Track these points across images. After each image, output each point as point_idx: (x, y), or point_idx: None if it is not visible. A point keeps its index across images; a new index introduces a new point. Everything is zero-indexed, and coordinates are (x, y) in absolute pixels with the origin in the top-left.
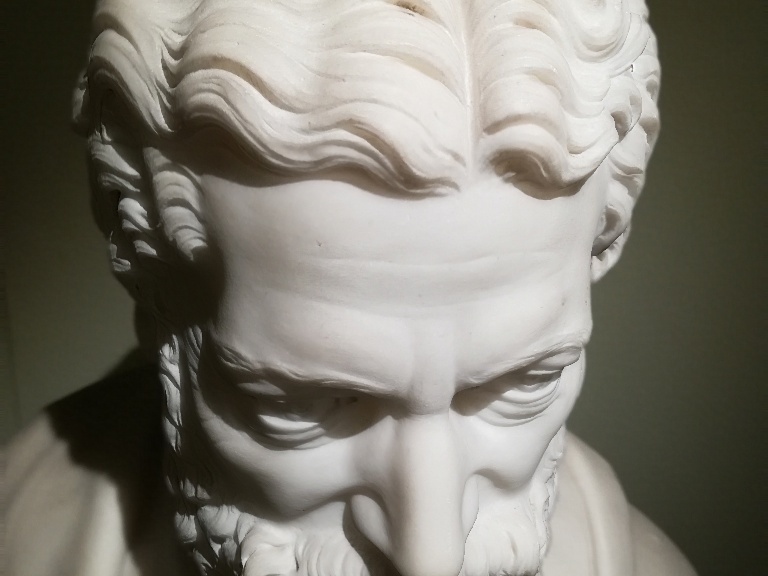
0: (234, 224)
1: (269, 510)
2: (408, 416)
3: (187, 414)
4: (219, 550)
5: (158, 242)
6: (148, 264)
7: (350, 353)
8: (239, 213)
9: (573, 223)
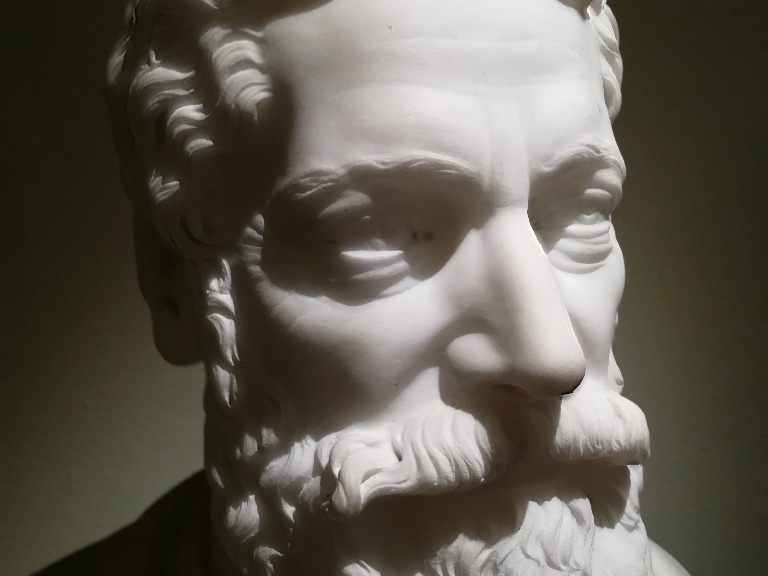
0: (303, 48)
1: (355, 404)
2: (492, 213)
3: (245, 341)
4: (293, 513)
5: (215, 128)
6: (199, 173)
7: (433, 127)
8: (307, 36)
9: (587, 45)
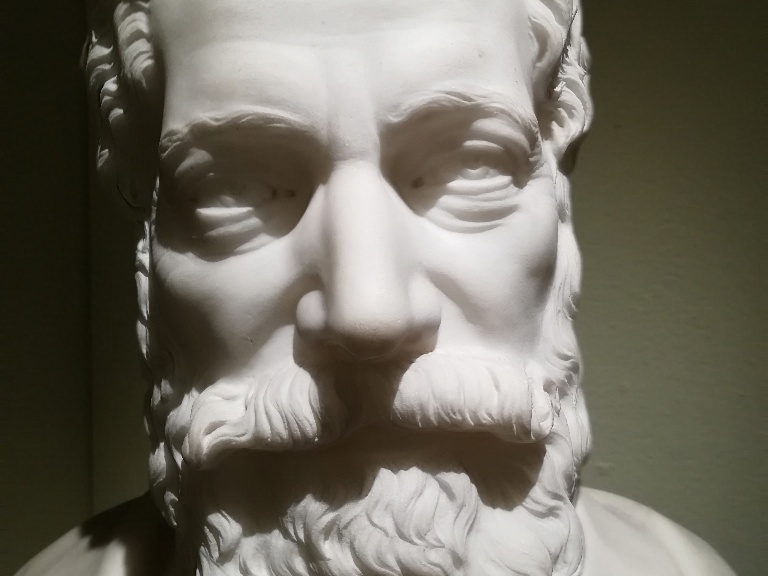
0: (169, 14)
1: (220, 358)
2: (333, 168)
3: (153, 297)
4: (182, 461)
5: (124, 97)
6: (121, 140)
7: (261, 81)
8: (172, 2)
9: None
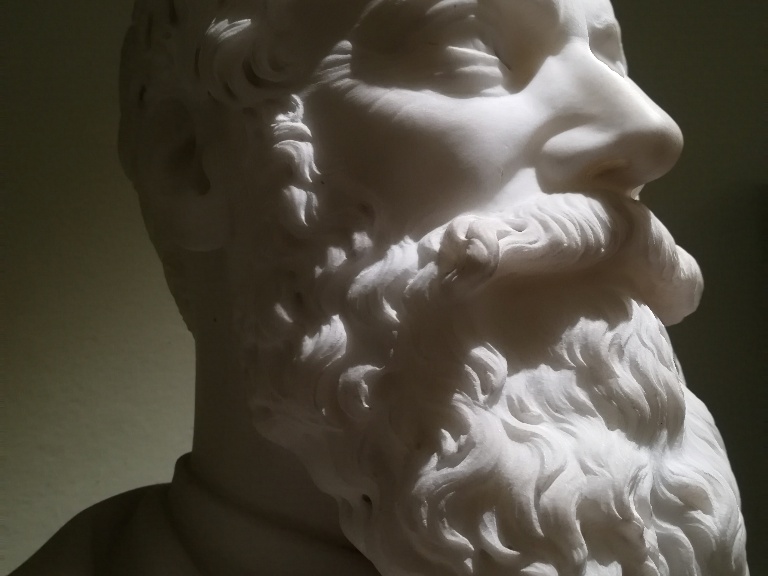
0: None
1: (463, 192)
2: (568, 41)
3: (326, 157)
4: (396, 315)
5: None
6: (274, 12)
7: None
8: None
9: None
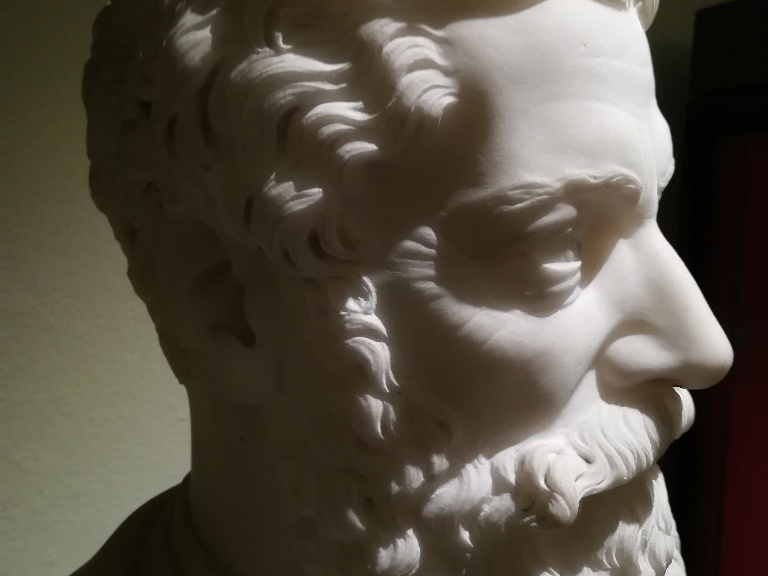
0: (500, 55)
1: (537, 415)
2: (642, 225)
3: (404, 364)
4: (469, 538)
5: (382, 130)
6: (348, 179)
7: (624, 144)
8: (503, 42)
9: None
